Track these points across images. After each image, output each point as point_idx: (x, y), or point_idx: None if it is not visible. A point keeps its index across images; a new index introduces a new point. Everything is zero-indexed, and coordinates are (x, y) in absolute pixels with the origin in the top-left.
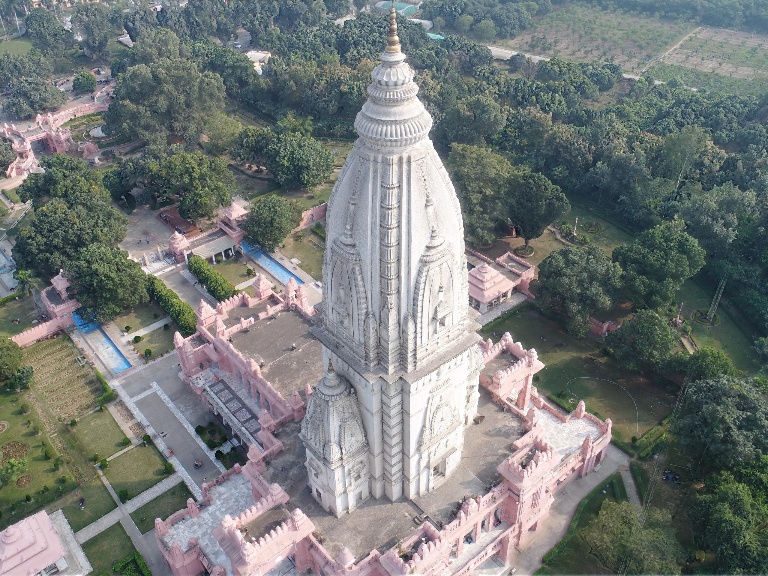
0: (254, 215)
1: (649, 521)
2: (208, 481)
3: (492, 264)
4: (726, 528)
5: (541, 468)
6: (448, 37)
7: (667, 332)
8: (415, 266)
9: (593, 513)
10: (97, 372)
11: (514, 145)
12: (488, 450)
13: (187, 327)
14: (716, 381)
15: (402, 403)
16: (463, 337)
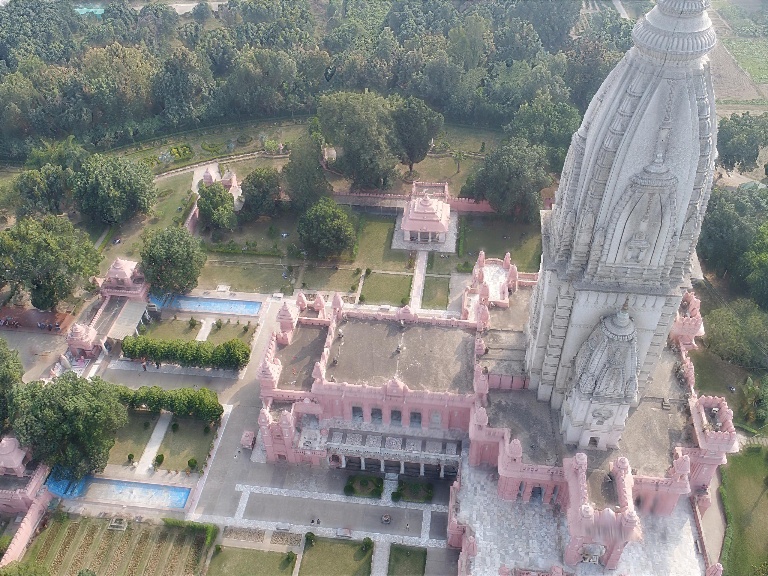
0: (163, 259)
1: (741, 312)
2: (413, 525)
3: (412, 198)
4: None
5: None
6: (110, 6)
7: None
8: None
9: None
10: (168, 519)
11: (307, 88)
12: None
13: (215, 410)
14: None
15: None
16: None
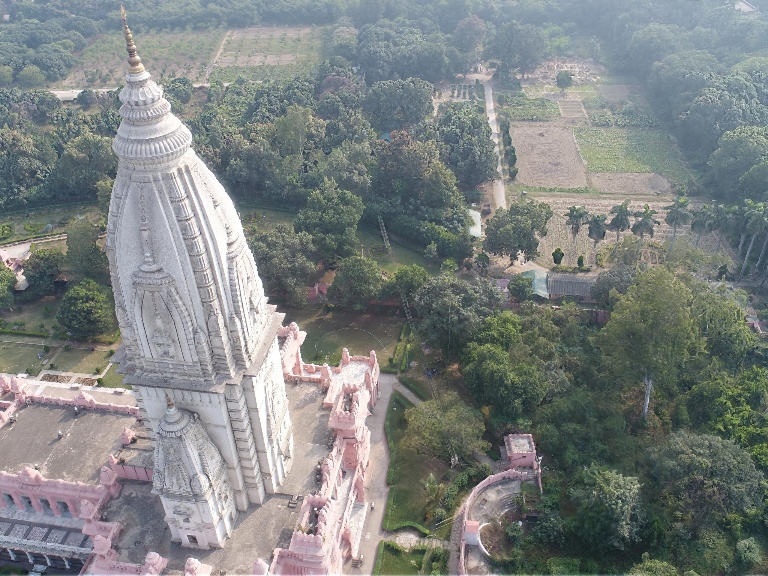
0: None
1: (445, 405)
2: None
3: None
4: (498, 376)
5: (361, 406)
6: None
7: (372, 267)
8: (225, 265)
9: (398, 429)
10: None
11: None
12: (307, 420)
13: None
14: (429, 284)
15: (246, 403)
16: (270, 320)
